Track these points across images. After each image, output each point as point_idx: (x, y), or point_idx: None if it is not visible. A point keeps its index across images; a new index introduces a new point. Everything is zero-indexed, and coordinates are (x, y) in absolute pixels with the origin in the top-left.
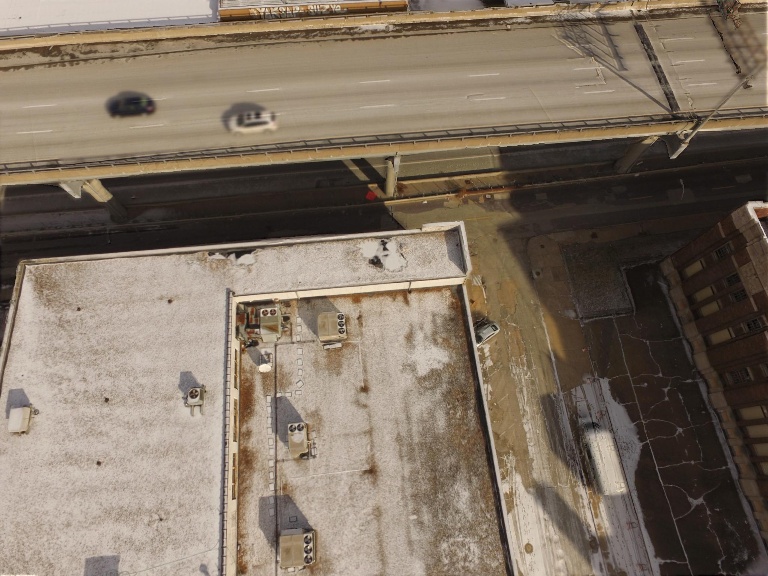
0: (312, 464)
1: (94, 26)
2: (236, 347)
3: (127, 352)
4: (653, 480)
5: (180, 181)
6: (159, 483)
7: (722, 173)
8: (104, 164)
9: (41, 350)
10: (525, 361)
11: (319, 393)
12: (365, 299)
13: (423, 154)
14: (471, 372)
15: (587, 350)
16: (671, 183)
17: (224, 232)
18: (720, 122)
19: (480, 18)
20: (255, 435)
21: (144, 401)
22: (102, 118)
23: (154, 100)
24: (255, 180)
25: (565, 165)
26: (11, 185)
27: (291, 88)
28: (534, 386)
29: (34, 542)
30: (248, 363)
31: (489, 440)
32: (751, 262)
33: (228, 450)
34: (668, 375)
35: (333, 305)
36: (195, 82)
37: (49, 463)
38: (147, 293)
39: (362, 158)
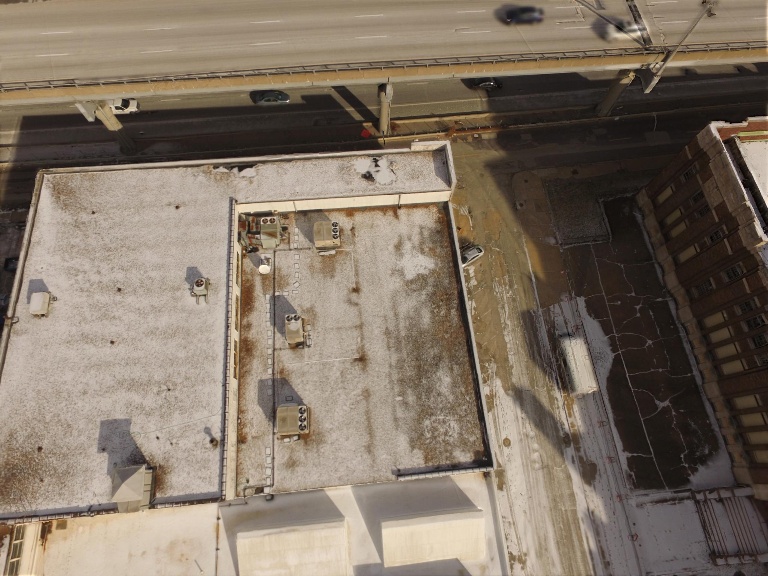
0: (307, 352)
1: None
2: (238, 250)
3: (138, 250)
4: (623, 385)
5: (186, 119)
6: (167, 360)
7: (697, 118)
8: (117, 81)
9: (59, 247)
10: (507, 281)
11: (314, 293)
12: (358, 213)
13: (415, 97)
14: (455, 277)
15: (565, 272)
16: (649, 126)
17: None
18: (689, 54)
19: None
20: (255, 327)
21: (153, 291)
22: (115, 44)
23: (163, 29)
24: (256, 118)
25: (549, 108)
26: (26, 120)
27: (291, 20)
28: (515, 303)
29: (54, 407)
30: (249, 266)
31: (470, 334)
32: (713, 177)
33: (230, 332)
34: (640, 294)
35: (328, 218)
36: (202, 14)
37: (67, 341)
38: (156, 200)
39: (358, 100)
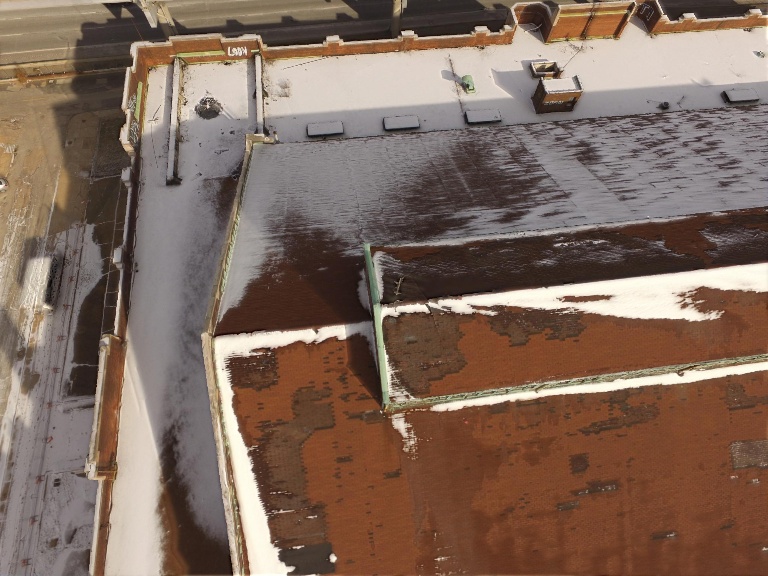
0: None
1: None
2: None
3: None
4: (98, 303)
5: None
6: None
7: None
8: None
9: None
10: (25, 212)
11: None
12: None
13: (4, 48)
14: None
15: (86, 202)
16: None
17: None
18: None
19: None
20: None
21: None
22: None
23: None
24: None
25: None
26: None
27: None
28: (24, 231)
29: None
30: None
31: None
32: None
33: None
34: None
35: None
36: None
37: None
38: None
39: None
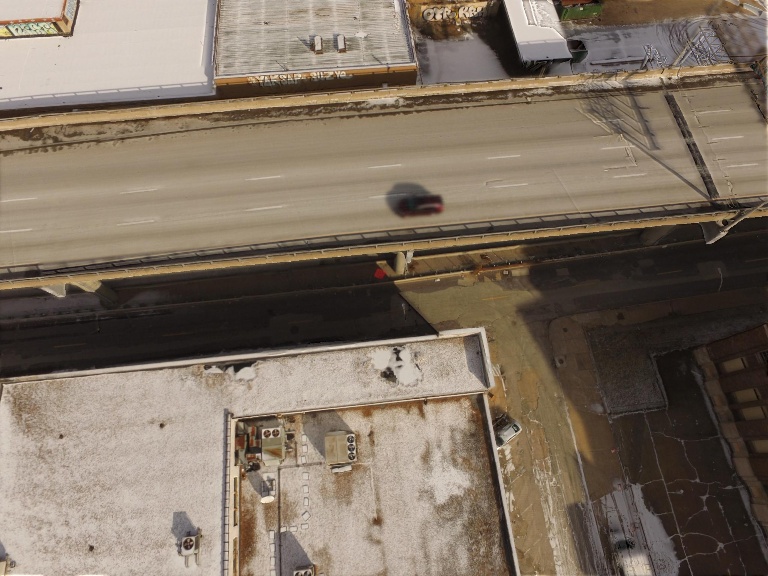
0: None
1: (80, 97)
2: (235, 475)
3: (114, 489)
4: None
5: None
6: None
7: (756, 243)
8: (88, 272)
9: (19, 487)
10: (550, 464)
11: (327, 527)
12: (377, 412)
13: None
14: (495, 499)
15: (617, 451)
16: (701, 255)
17: (222, 317)
18: (764, 212)
19: (497, 89)
20: None
21: (133, 549)
22: (87, 213)
23: (144, 191)
24: None
25: (587, 236)
26: None
27: (293, 175)
28: (560, 494)
29: None
30: (249, 491)
31: None
32: None
33: None
34: (706, 481)
35: (342, 419)
36: (189, 169)
37: None
38: (137, 416)
39: None
